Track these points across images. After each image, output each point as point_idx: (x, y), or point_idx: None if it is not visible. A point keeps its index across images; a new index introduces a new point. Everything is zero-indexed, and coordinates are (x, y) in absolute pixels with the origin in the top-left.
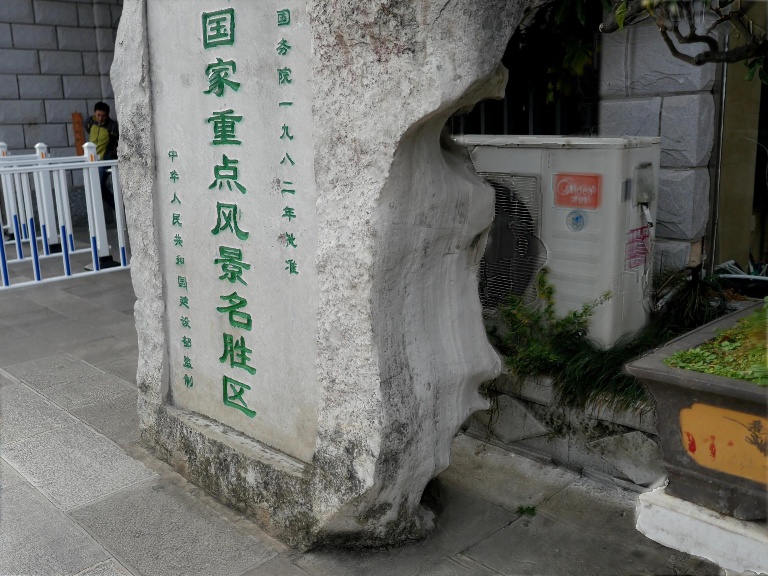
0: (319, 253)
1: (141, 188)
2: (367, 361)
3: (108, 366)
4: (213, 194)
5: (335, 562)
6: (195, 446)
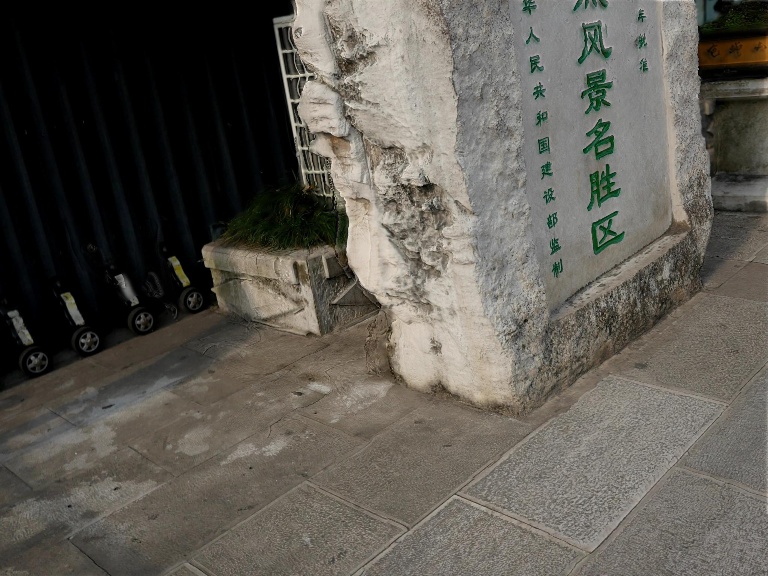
0: (670, 40)
1: (493, 32)
2: (696, 110)
3: (145, 570)
4: (579, 15)
5: (705, 276)
6: (616, 307)
